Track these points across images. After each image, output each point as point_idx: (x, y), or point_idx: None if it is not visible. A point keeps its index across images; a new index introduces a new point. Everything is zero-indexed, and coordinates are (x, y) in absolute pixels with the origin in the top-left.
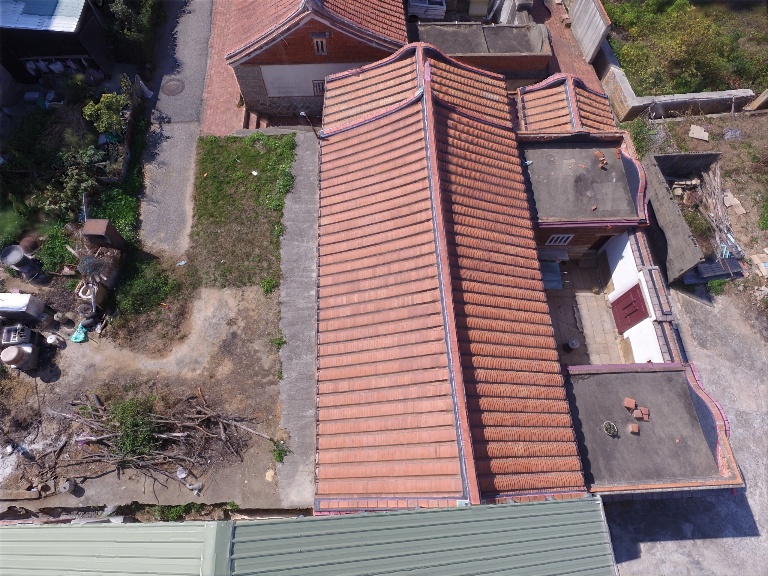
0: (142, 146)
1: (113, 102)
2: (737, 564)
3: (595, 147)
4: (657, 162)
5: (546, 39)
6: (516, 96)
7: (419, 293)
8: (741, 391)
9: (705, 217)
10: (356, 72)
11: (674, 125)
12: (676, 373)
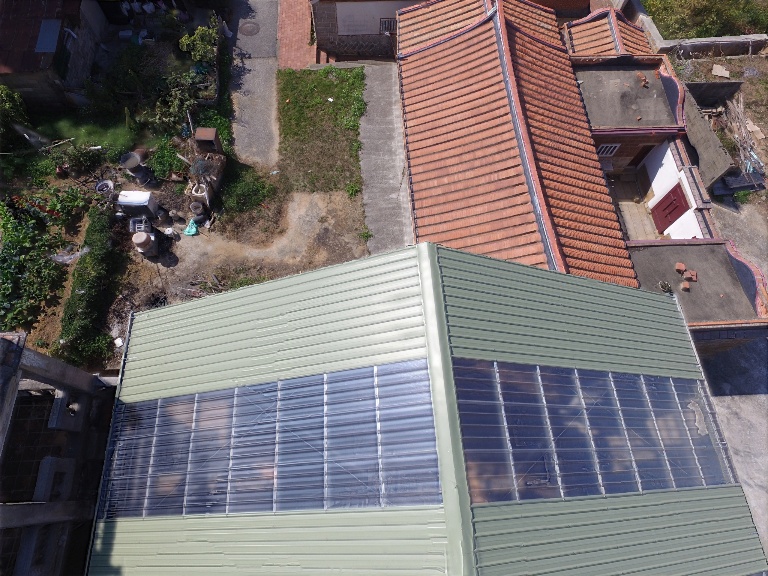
0: (229, 77)
1: (206, 35)
2: None
3: (637, 69)
4: None
5: None
6: (563, 30)
7: (503, 171)
8: (767, 281)
9: (730, 138)
10: (426, 4)
11: (698, 65)
12: (717, 246)
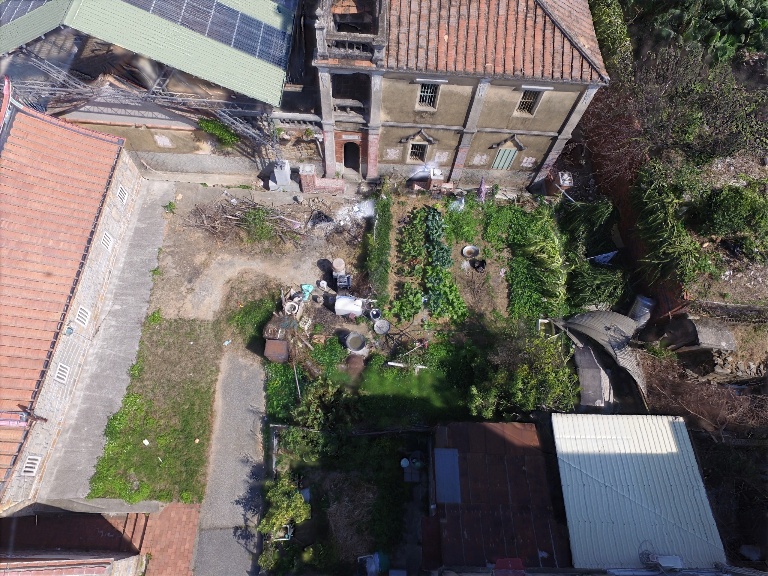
0: None
1: None
2: None
3: None
4: None
5: None
6: None
7: None
8: None
9: None
10: None
11: None
12: None
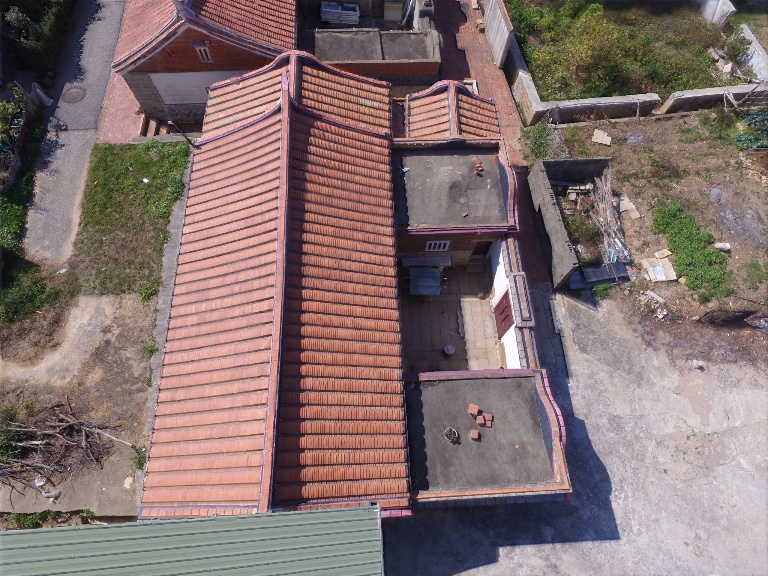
0: (35, 154)
1: (1, 111)
2: (594, 567)
3: (473, 154)
4: (548, 167)
5: (436, 46)
6: (405, 103)
7: (259, 302)
8: (616, 395)
9: (594, 222)
10: (237, 80)
11: (578, 130)
12: (526, 379)
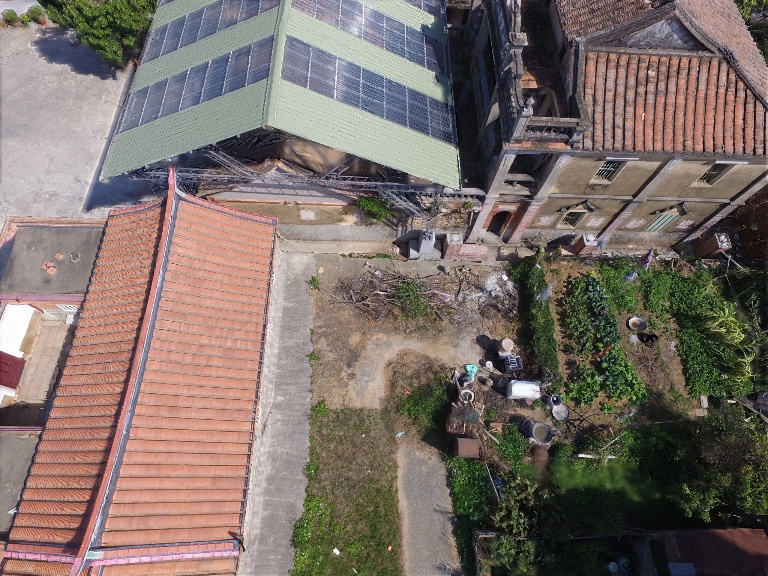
0: None
1: None
2: None
3: None
4: None
5: None
6: None
7: (173, 331)
8: None
9: None
10: None
11: None
12: (3, 291)
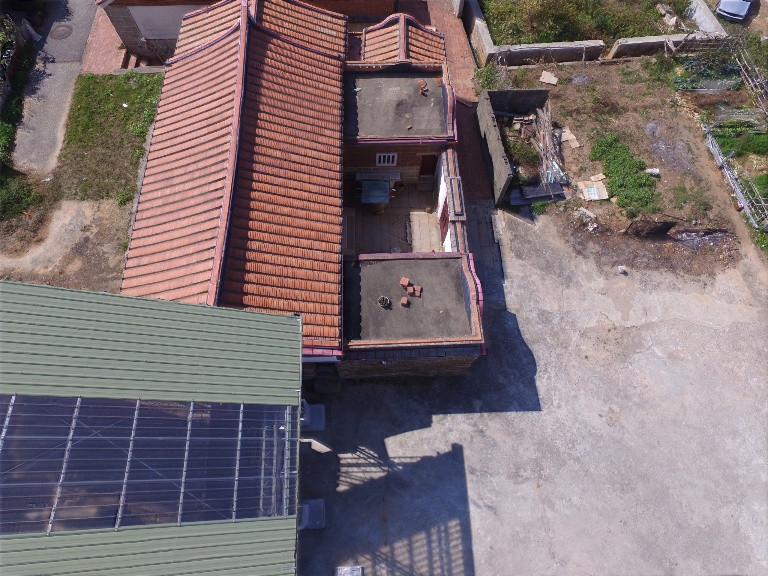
0: (24, 81)
1: None
2: (516, 433)
3: (420, 77)
4: (494, 98)
5: None
6: (362, 36)
7: (215, 182)
8: (547, 294)
9: (535, 147)
10: (207, 9)
11: (527, 71)
12: (454, 260)
